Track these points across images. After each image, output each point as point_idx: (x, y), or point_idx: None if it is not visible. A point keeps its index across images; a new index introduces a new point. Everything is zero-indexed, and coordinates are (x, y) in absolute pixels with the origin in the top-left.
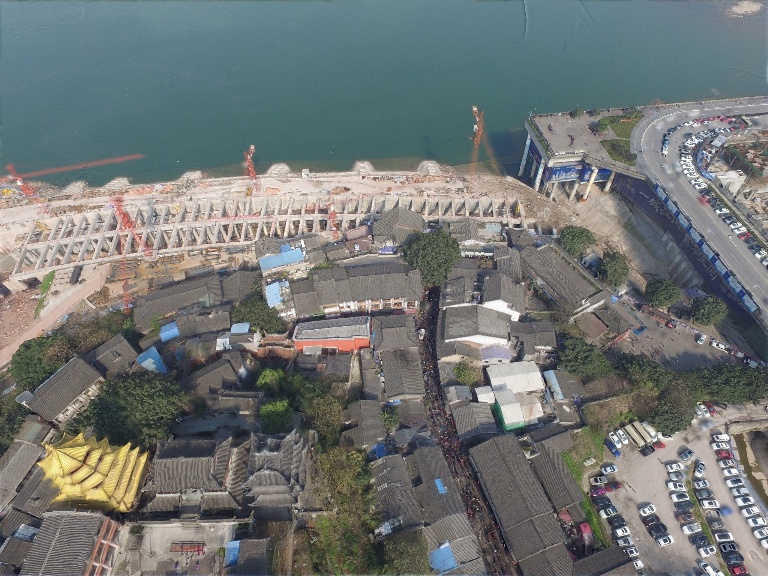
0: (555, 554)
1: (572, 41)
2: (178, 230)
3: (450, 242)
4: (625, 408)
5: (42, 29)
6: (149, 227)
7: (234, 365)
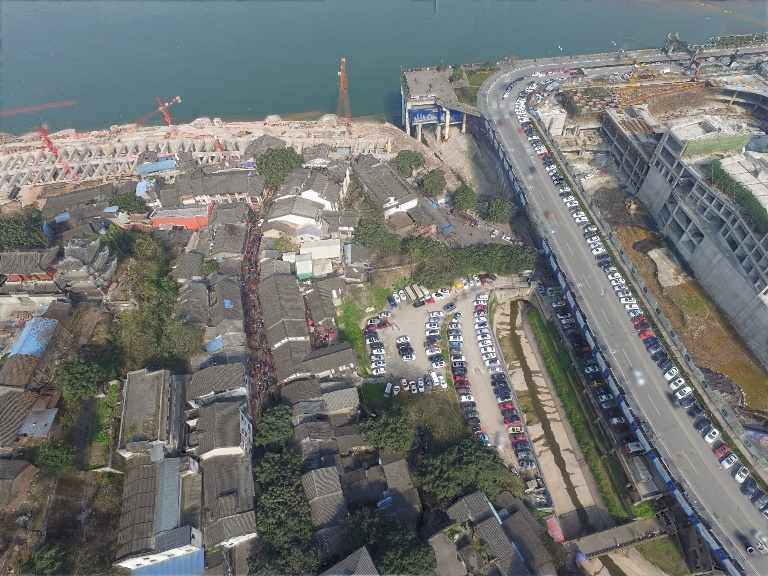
0: (299, 345)
1: (485, 18)
2: (105, 164)
3: (292, 155)
4: (408, 275)
5: (26, 15)
6: (81, 161)
7: (94, 226)
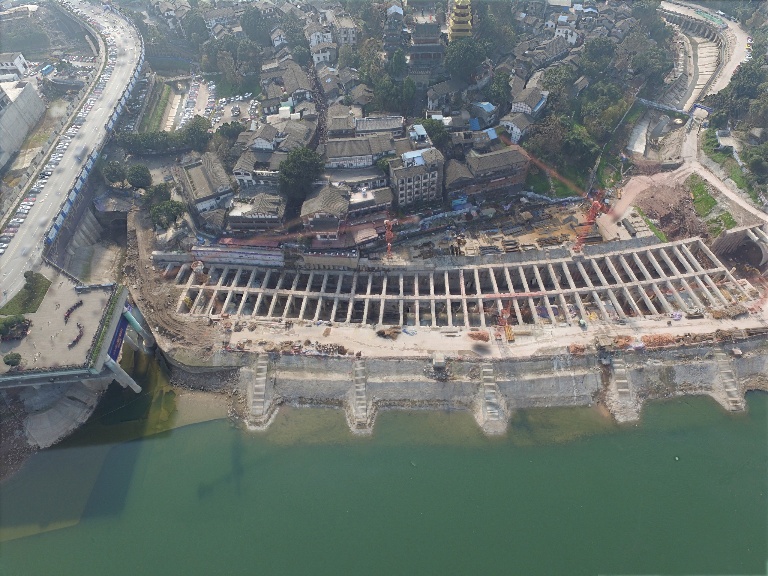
0: None
1: None
2: None
3: None
4: None
5: None
6: (605, 287)
7: None
